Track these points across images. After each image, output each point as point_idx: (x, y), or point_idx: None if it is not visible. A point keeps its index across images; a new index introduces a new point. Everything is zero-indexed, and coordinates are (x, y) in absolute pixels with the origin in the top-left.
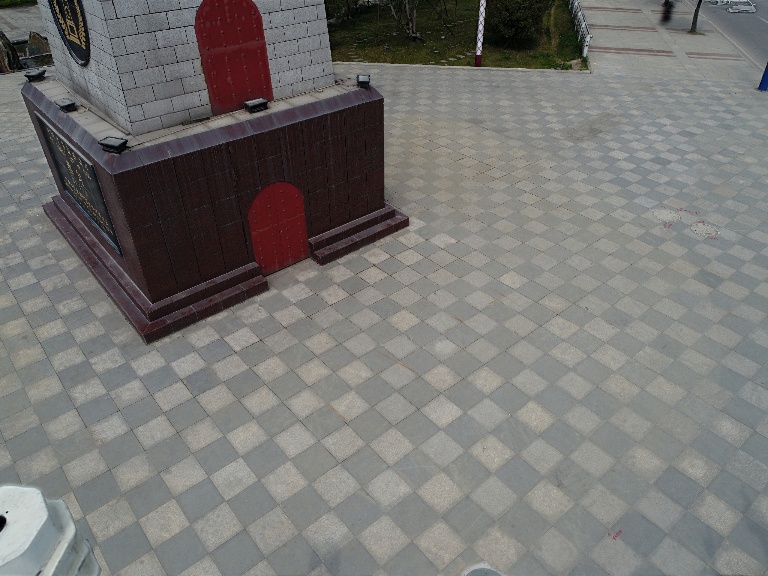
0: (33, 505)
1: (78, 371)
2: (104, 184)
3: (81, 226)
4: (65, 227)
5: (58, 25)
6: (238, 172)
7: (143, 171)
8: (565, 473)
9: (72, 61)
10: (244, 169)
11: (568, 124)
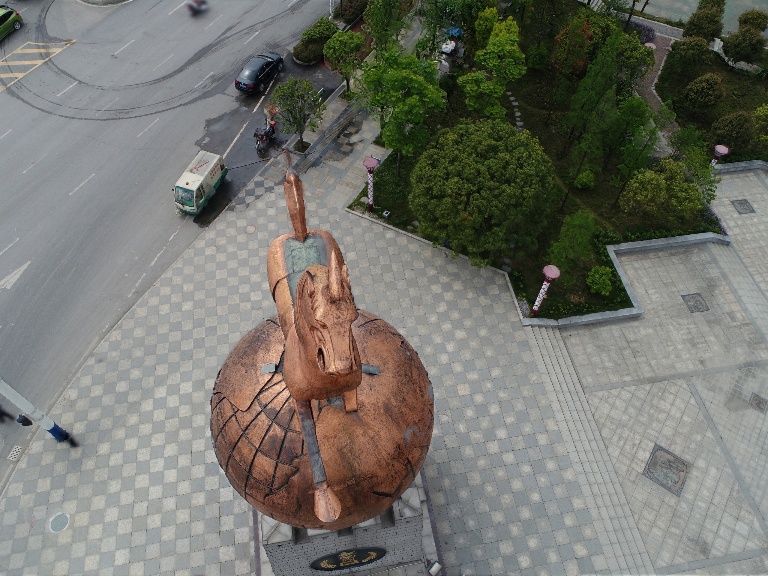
0: None
1: None
2: None
3: None
4: None
5: None
6: None
7: None
8: None
9: None
10: None
11: None
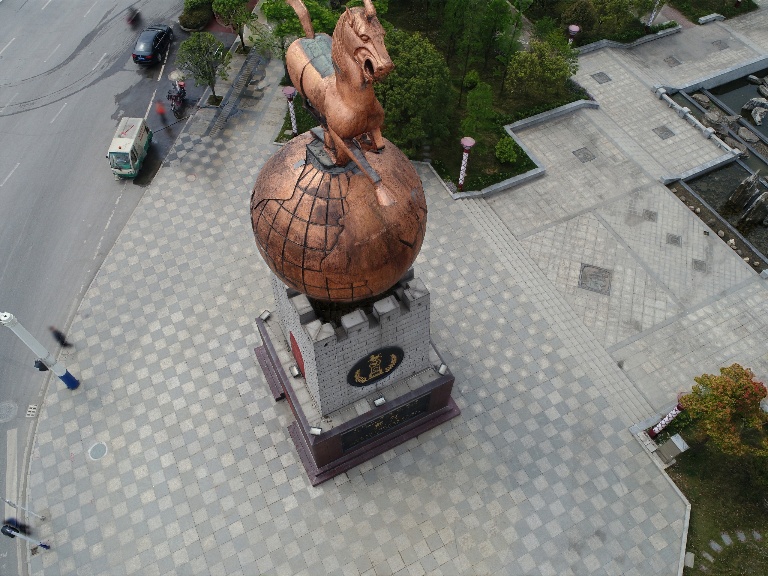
0: (6, 319)
1: (249, 330)
2: None
3: None
4: None
5: None
6: None
7: None
8: (120, 496)
9: None
10: None
11: None
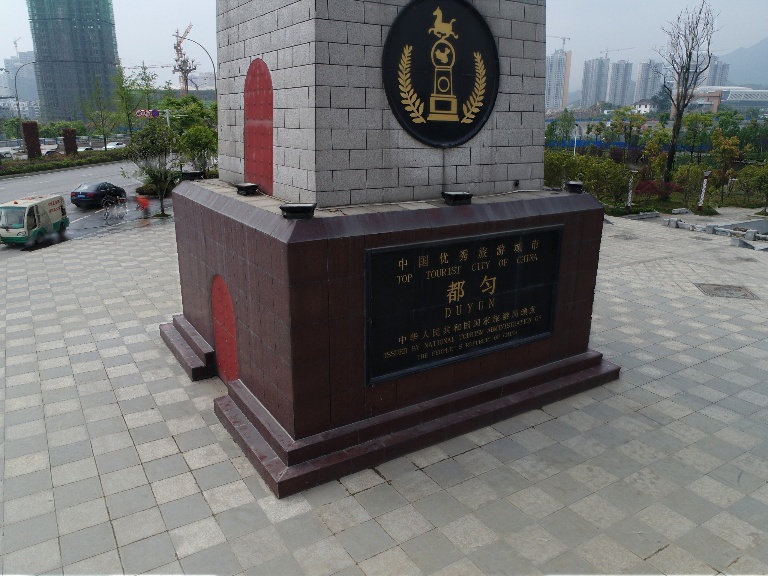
0: None
1: None
2: None
3: None
4: None
5: None
6: None
7: None
8: None
9: None
10: None
11: None
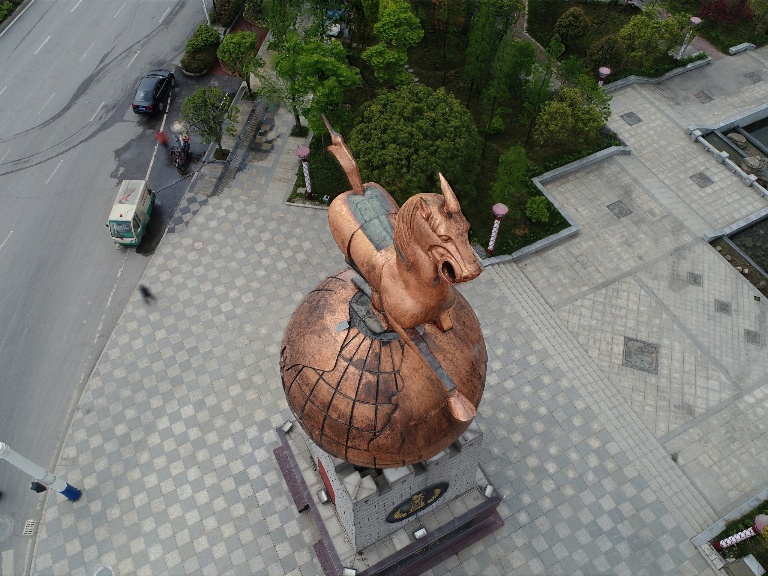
0: None
1: (266, 426)
2: None
3: None
4: None
5: None
6: None
7: None
8: None
9: None
10: None
11: None
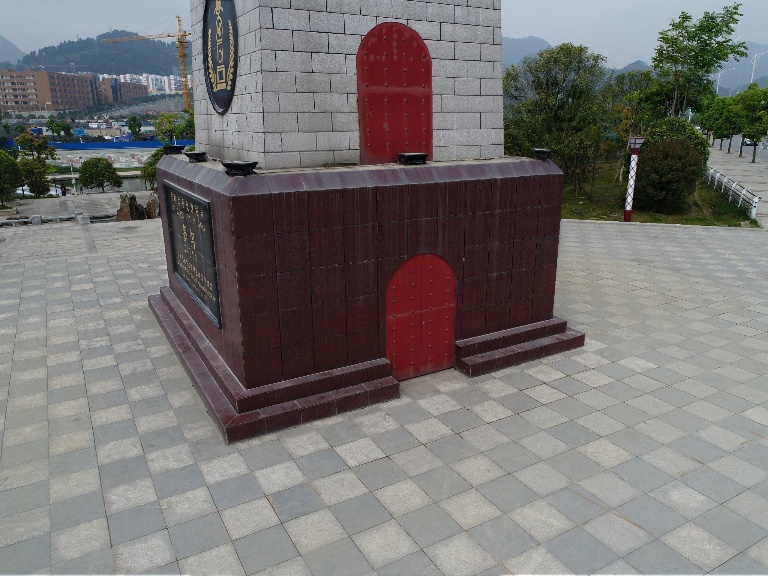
0: None
1: (127, 467)
2: (218, 222)
3: (182, 311)
4: (165, 315)
5: (207, 81)
6: (383, 229)
7: (269, 201)
8: None
9: (213, 117)
10: (390, 227)
11: (762, 268)
